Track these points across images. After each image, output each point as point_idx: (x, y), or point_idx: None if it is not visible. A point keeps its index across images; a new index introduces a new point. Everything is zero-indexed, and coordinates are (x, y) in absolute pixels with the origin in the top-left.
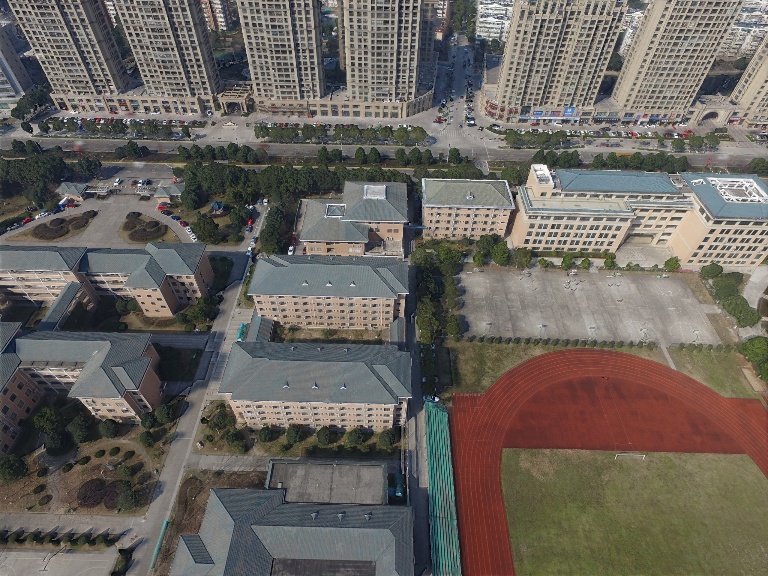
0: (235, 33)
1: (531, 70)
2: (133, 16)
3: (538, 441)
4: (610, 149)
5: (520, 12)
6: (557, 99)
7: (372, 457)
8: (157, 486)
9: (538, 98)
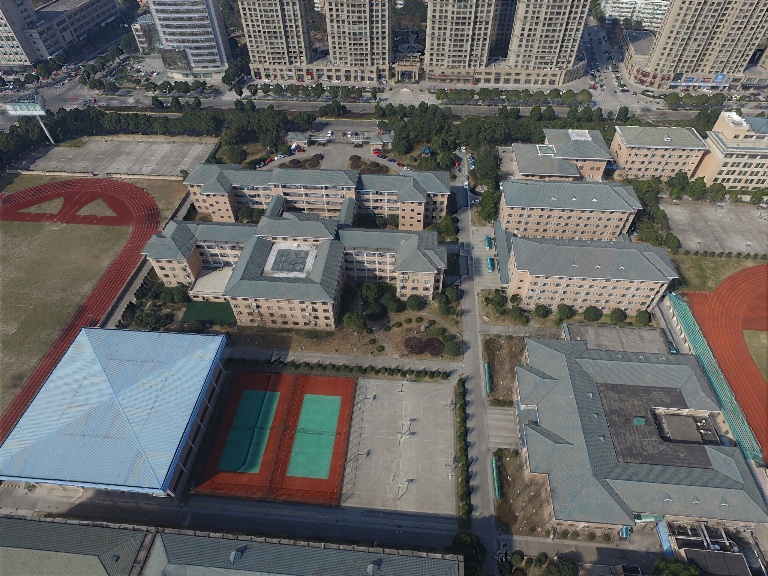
0: None
1: (689, 38)
2: None
3: None
4: None
5: None
6: (709, 66)
7: None
8: (464, 343)
9: (691, 65)
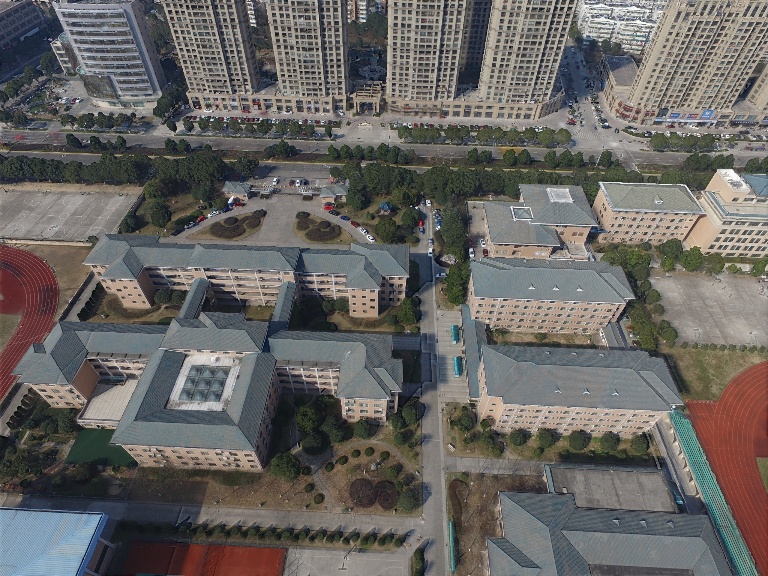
0: None
1: (675, 72)
2: (284, 16)
3: None
4: (755, 153)
5: (676, 14)
6: (696, 102)
7: (627, 463)
8: (424, 487)
9: (677, 100)
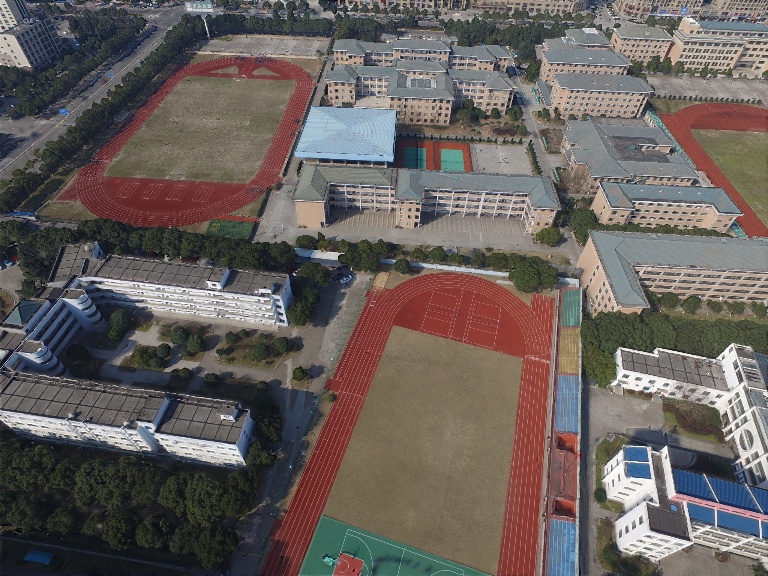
0: None
1: None
2: None
3: (708, 127)
4: None
5: None
6: (677, 1)
7: None
8: (528, 132)
9: (664, 0)
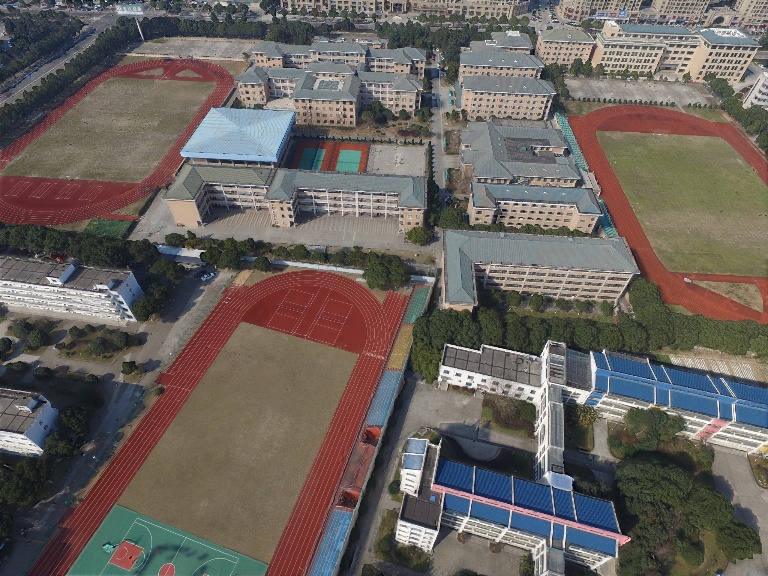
0: None
1: None
2: None
3: (614, 129)
4: None
5: None
6: (615, 5)
7: None
8: (433, 133)
9: (602, 4)
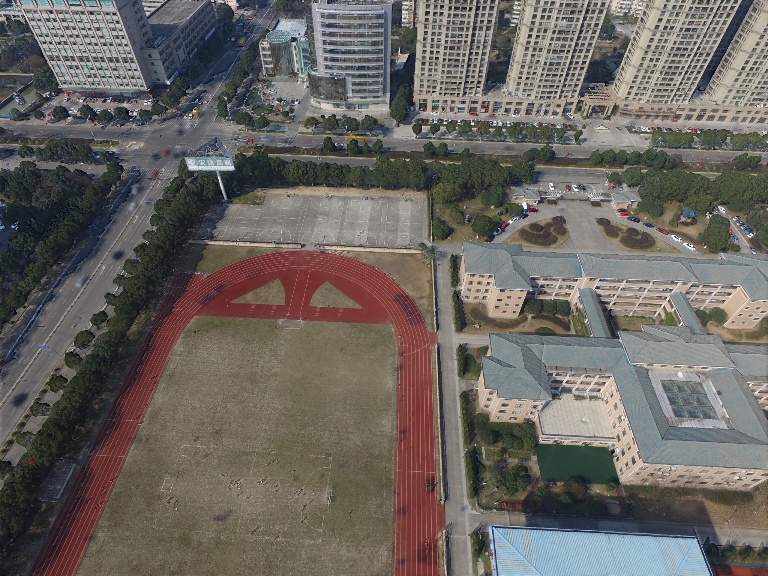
0: (505, 33)
1: None
2: (544, 18)
3: None
4: None
5: None
6: None
7: None
8: None
9: None
